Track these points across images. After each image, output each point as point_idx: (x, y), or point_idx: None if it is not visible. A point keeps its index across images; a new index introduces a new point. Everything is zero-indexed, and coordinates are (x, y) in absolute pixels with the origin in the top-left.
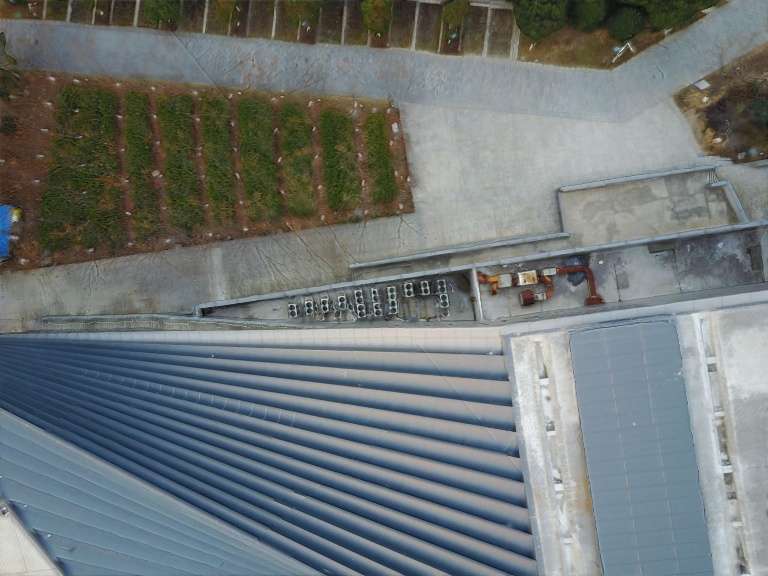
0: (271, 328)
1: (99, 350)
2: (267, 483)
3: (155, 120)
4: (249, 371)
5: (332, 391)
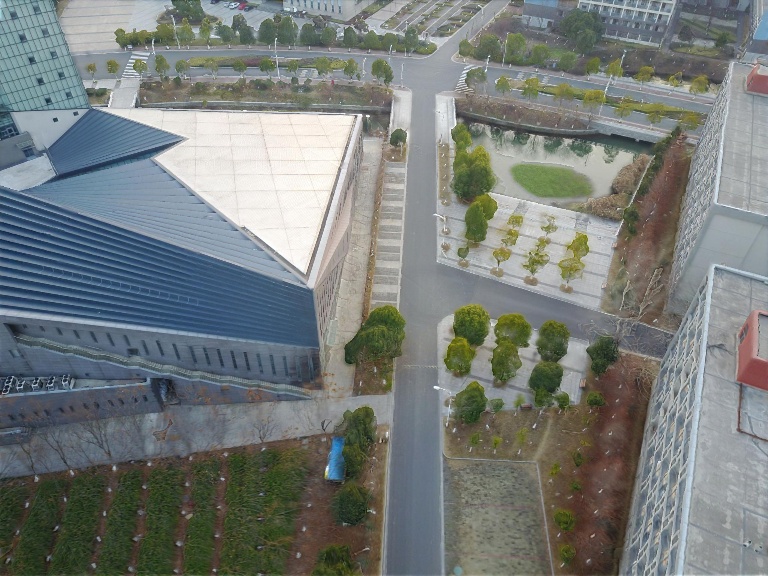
0: (71, 351)
1: (194, 322)
2: (67, 239)
3: (177, 568)
4: (68, 298)
5: (7, 283)
